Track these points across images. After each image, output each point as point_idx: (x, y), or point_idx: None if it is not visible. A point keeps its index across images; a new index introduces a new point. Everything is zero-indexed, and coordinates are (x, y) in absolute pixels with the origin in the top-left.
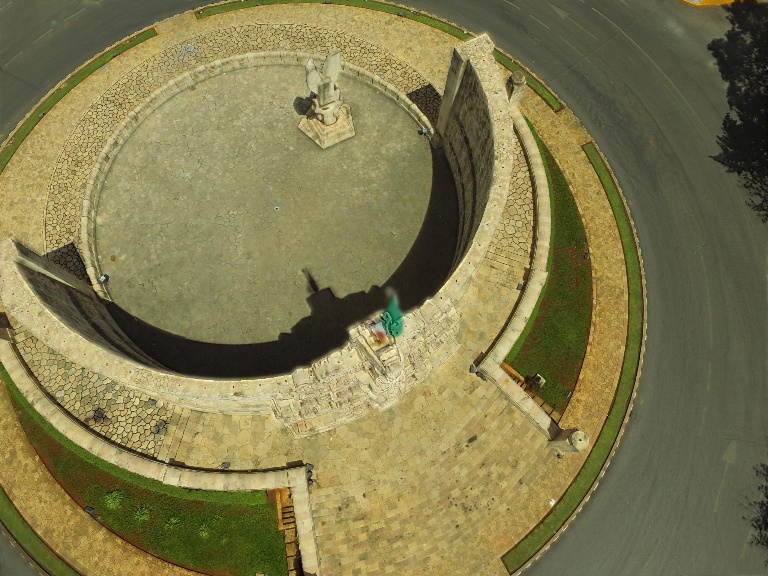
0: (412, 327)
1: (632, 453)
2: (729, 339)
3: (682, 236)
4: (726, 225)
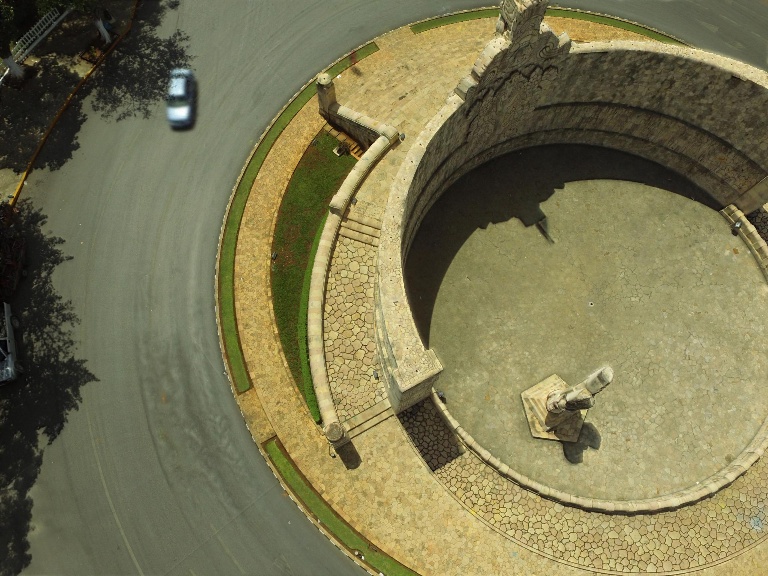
0: (489, 49)
1: (269, 108)
2: (156, 189)
3: (166, 284)
4: (114, 296)
